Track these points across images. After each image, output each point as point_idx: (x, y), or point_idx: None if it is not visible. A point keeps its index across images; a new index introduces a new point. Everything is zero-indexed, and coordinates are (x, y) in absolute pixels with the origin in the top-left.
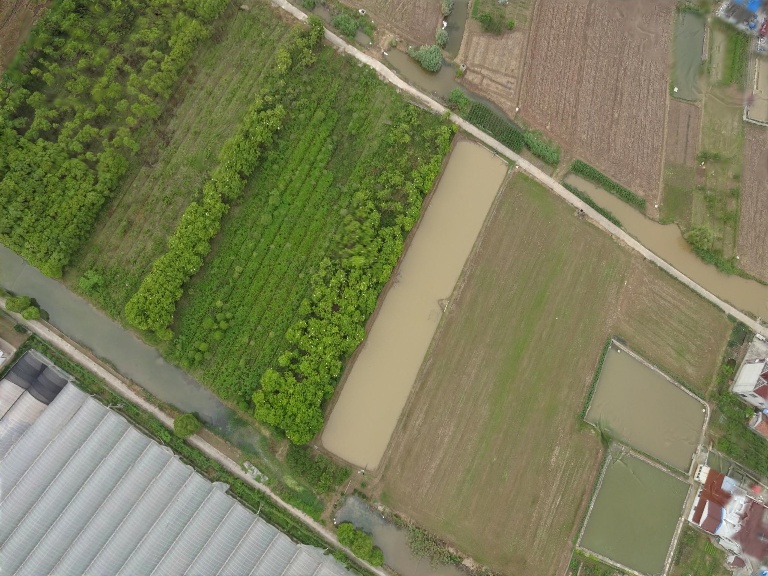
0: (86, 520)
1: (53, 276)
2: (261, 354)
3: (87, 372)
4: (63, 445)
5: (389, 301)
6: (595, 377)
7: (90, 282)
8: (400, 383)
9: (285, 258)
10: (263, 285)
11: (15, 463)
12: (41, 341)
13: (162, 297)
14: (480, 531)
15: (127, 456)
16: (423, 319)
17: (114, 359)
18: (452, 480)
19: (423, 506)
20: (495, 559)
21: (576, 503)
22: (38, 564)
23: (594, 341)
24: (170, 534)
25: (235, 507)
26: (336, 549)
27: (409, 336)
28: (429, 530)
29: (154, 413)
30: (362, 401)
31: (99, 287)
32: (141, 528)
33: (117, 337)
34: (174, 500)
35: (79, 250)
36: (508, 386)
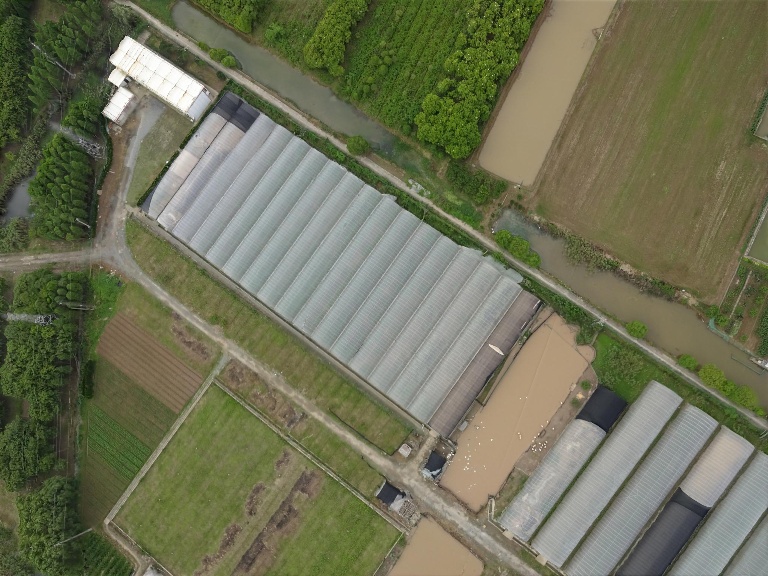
0: (279, 222)
1: (245, 30)
2: (421, 86)
3: (274, 107)
4: (259, 162)
5: (542, 33)
6: (767, 92)
7: (274, 31)
8: (554, 108)
9: (441, 1)
10: (421, 27)
11: (223, 176)
12: (237, 85)
13: (334, 36)
14: (638, 240)
15: (310, 170)
16: (577, 48)
17: (295, 99)
18: (609, 194)
19: (579, 217)
20: (654, 266)
21: (744, 215)
22: (244, 254)
23: (766, 58)
24: (347, 232)
25: (402, 212)
26: (495, 252)
27: (563, 64)
28: (585, 238)
29: (330, 140)
30: (517, 126)
31: (281, 38)
32: (323, 227)
33: (297, 81)
34: (350, 206)
35: (264, 9)
36: (668, 106)
